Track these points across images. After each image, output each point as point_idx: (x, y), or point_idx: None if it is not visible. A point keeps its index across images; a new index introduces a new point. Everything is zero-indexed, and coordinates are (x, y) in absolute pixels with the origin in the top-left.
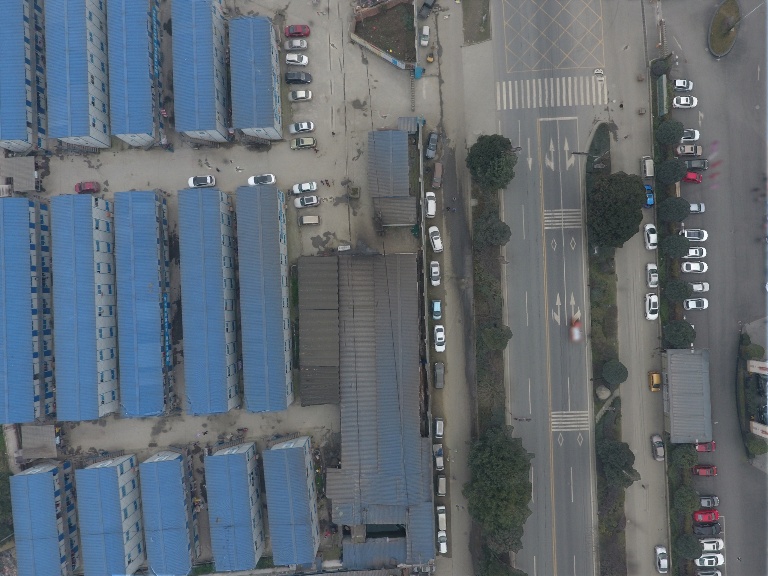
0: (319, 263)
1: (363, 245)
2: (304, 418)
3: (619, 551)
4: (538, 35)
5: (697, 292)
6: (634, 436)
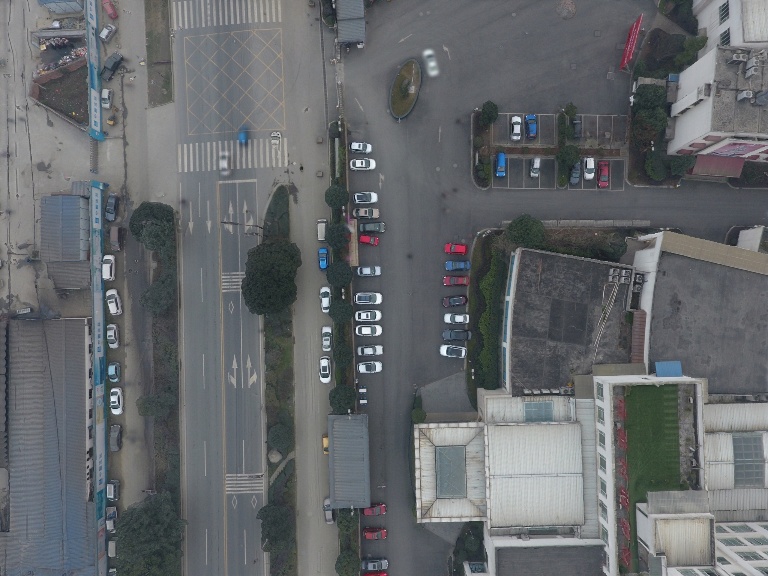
0: None
1: (45, 307)
2: None
3: None
4: (219, 97)
5: (371, 355)
6: (309, 498)
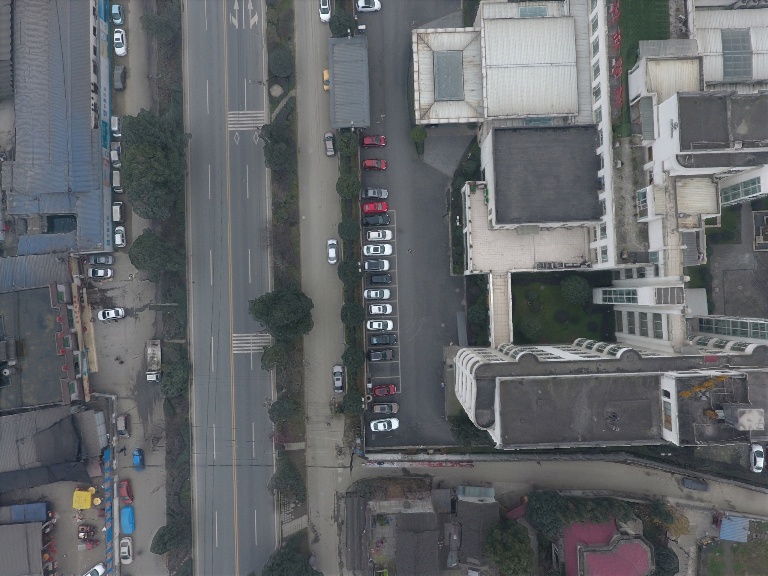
0: None
1: None
2: None
3: (293, 245)
4: None
5: None
6: (310, 136)
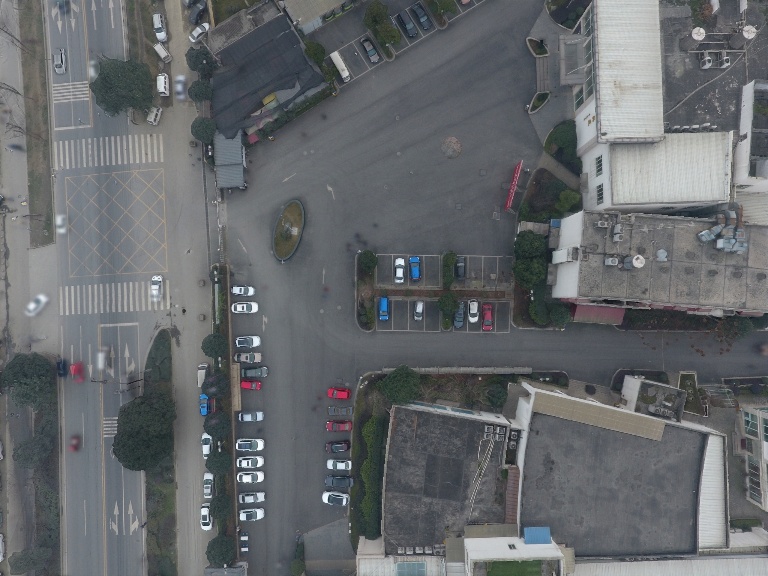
0: None
1: None
2: None
3: None
4: (100, 239)
5: (253, 502)
6: None
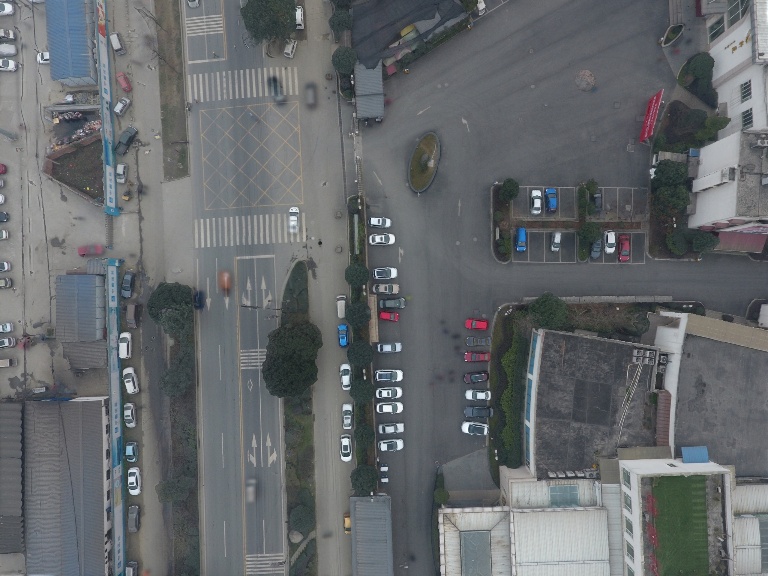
0: (4, 410)
1: (61, 386)
2: (0, 562)
3: None
4: (236, 172)
5: (392, 433)
6: None
